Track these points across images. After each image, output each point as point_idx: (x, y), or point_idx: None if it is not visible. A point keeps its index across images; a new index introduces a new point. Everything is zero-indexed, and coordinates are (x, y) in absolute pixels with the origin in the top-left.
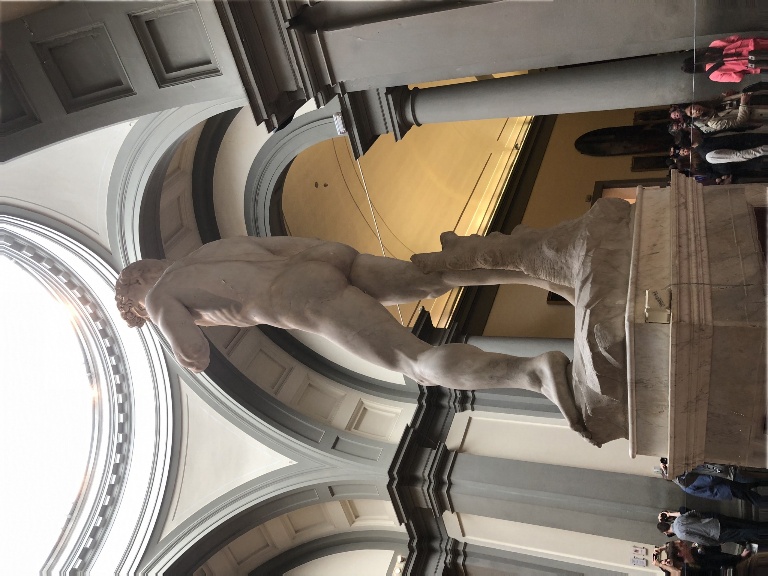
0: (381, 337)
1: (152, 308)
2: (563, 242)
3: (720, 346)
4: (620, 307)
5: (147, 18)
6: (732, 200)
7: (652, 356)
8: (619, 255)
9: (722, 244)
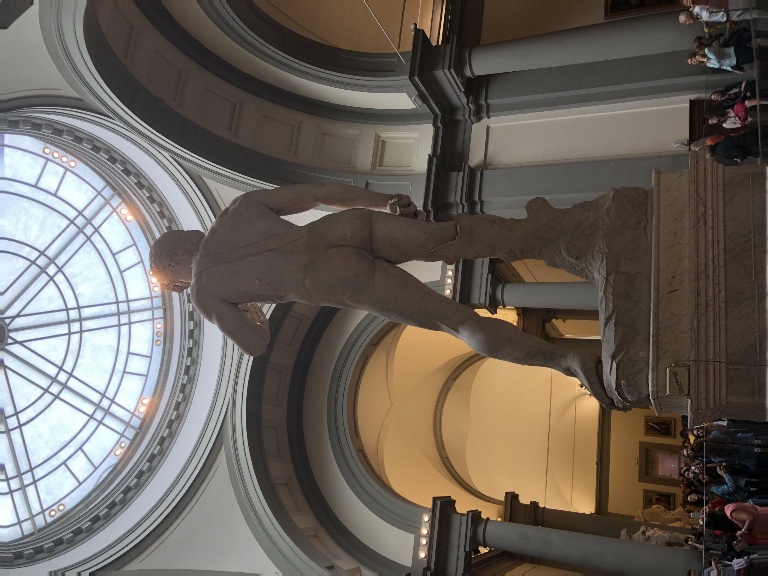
0: (421, 315)
1: (204, 314)
2: (582, 250)
3: (732, 404)
4: (643, 361)
5: None
6: (754, 196)
7: None
8: (639, 283)
9: (740, 277)
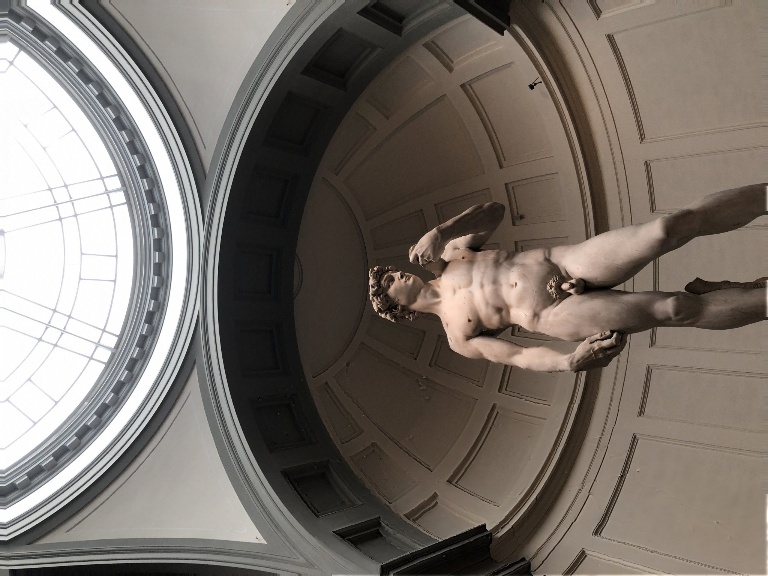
0: None
1: None
2: None
3: None
4: None
5: (382, 531)
6: None
7: None
8: None
9: None
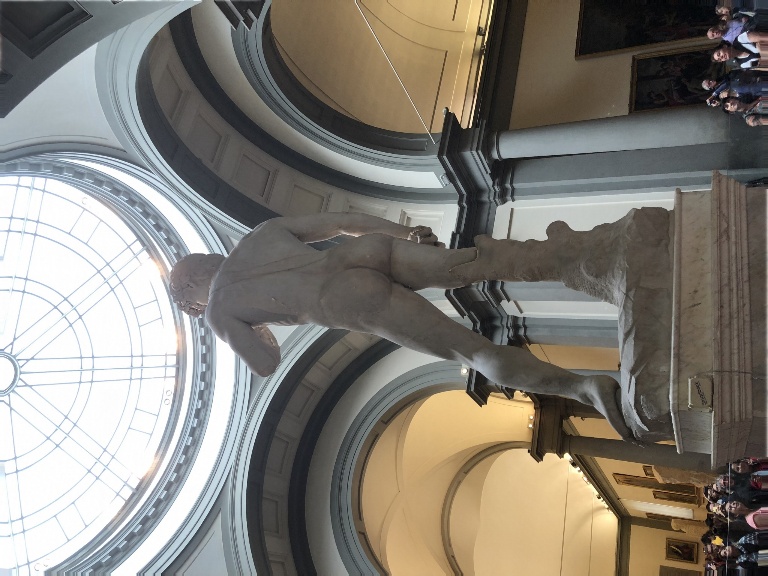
0: (435, 340)
1: (216, 331)
2: (602, 268)
3: (759, 423)
4: (664, 376)
5: None
6: None
7: (696, 422)
8: (660, 298)
9: (765, 291)
